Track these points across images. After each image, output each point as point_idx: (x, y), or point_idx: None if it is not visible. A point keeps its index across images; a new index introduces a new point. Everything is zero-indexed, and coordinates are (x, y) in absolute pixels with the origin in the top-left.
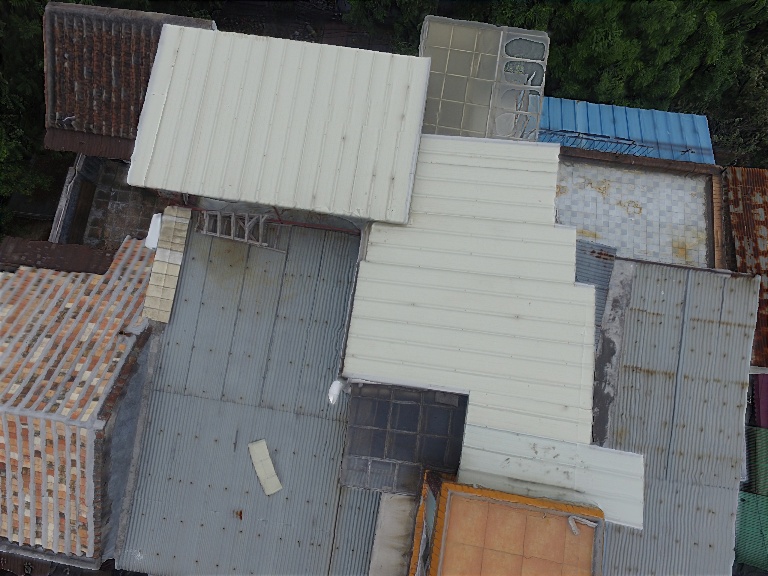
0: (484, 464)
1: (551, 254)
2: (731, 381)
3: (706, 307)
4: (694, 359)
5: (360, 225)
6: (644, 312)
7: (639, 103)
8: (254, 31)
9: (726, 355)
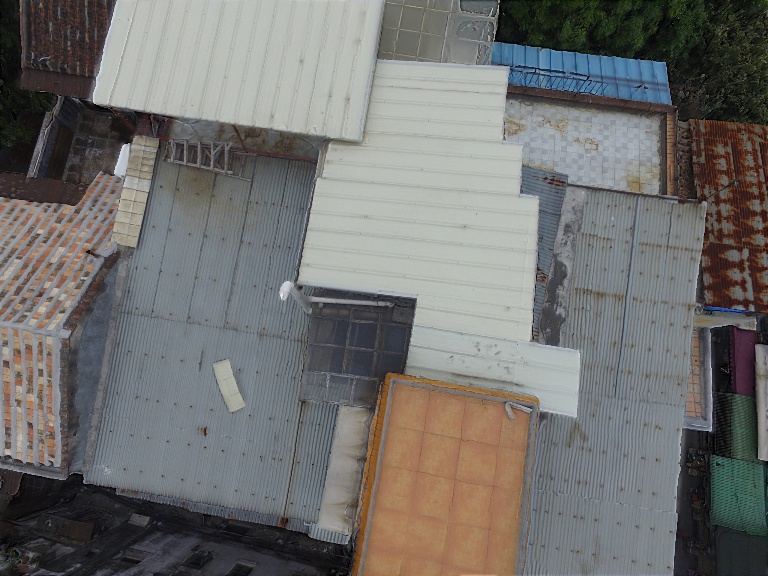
0: (429, 361)
1: (498, 168)
2: (678, 303)
3: (654, 232)
4: (643, 282)
5: (317, 145)
6: (595, 237)
7: (604, 54)
8: None
9: (673, 278)
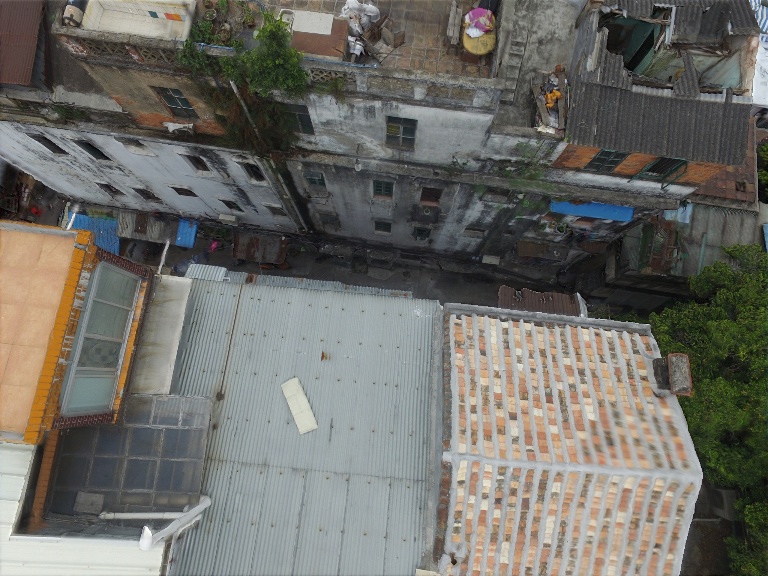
0: (5, 459)
1: None
2: None
3: None
4: None
5: None
6: None
7: None
8: None
9: None
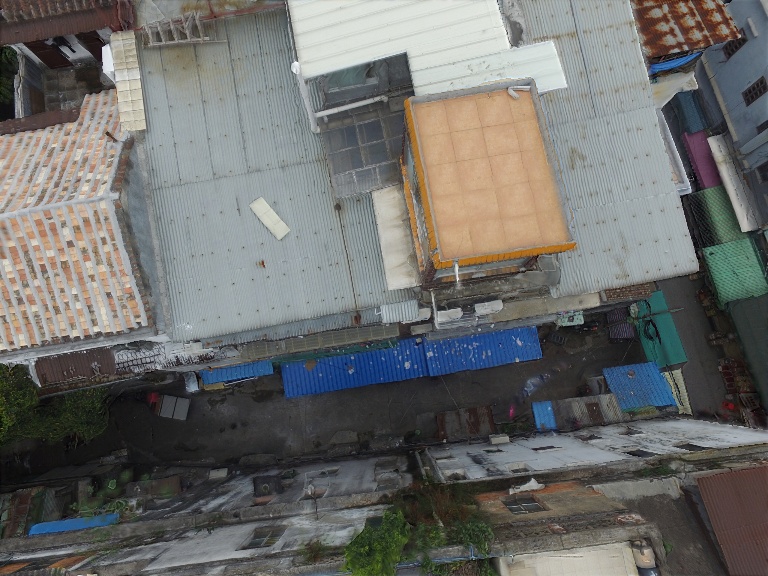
0: None
1: None
2: (620, 23)
3: None
4: (586, 16)
5: None
6: None
7: None
8: None
9: (610, 5)
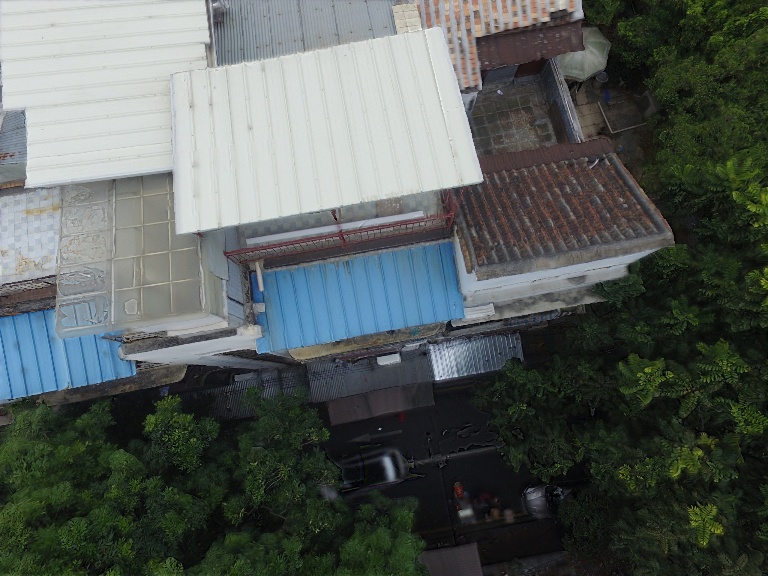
0: None
1: (26, 82)
2: None
3: None
4: None
5: None
6: None
7: (7, 438)
8: (588, 569)
9: None
